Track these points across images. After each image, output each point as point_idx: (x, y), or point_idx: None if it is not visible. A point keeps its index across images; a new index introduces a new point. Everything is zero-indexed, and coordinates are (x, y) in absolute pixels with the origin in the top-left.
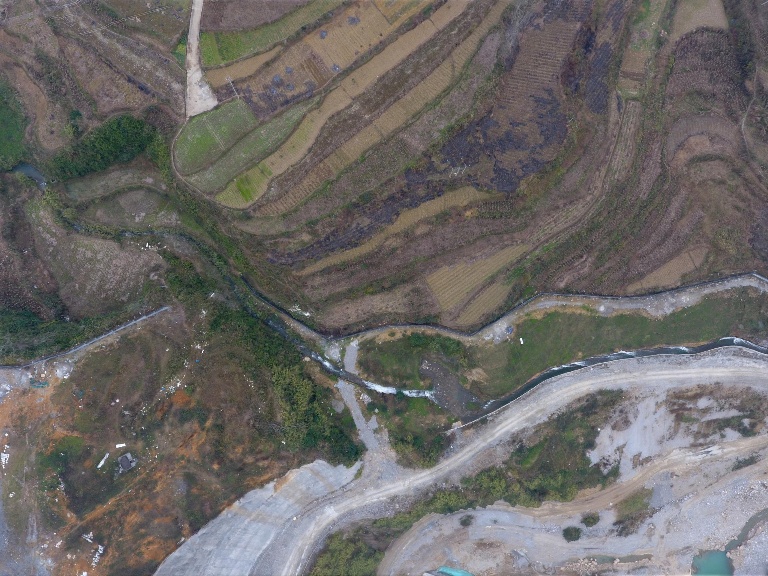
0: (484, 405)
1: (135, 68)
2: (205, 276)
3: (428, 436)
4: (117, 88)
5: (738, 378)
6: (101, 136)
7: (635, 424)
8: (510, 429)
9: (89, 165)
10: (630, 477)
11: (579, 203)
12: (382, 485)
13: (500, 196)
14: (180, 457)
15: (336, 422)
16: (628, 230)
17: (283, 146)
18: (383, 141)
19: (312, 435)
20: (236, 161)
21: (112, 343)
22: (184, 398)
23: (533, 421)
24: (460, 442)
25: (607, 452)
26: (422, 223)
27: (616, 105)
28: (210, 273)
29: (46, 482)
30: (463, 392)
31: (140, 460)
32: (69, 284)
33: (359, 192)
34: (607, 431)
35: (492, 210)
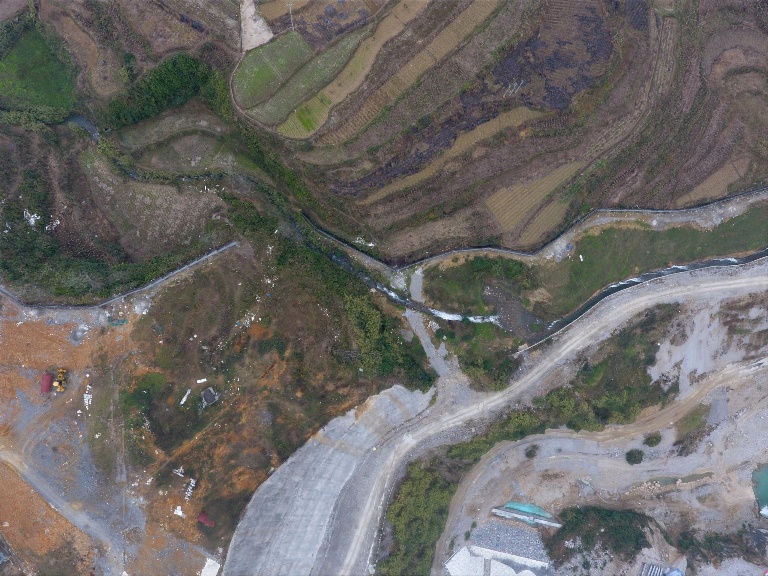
0: (548, 326)
1: (187, 7)
2: (266, 215)
3: (497, 360)
4: (170, 28)
5: None
6: (156, 77)
7: (691, 338)
8: (575, 348)
9: (143, 110)
10: (688, 394)
11: (627, 118)
12: (457, 410)
13: (553, 114)
14: (263, 388)
15: (407, 350)
16: (674, 143)
17: (340, 75)
18: (437, 65)
19: (387, 362)
20: (295, 92)
21: (186, 278)
22: (261, 330)
23: (597, 338)
24: (528, 364)
25: (666, 369)
26: (479, 145)
27: (655, 21)
28: (270, 212)
29: (132, 420)
30: (526, 315)
31: (222, 394)
32: (130, 232)
33: (417, 116)
34: (666, 346)
35: (546, 128)
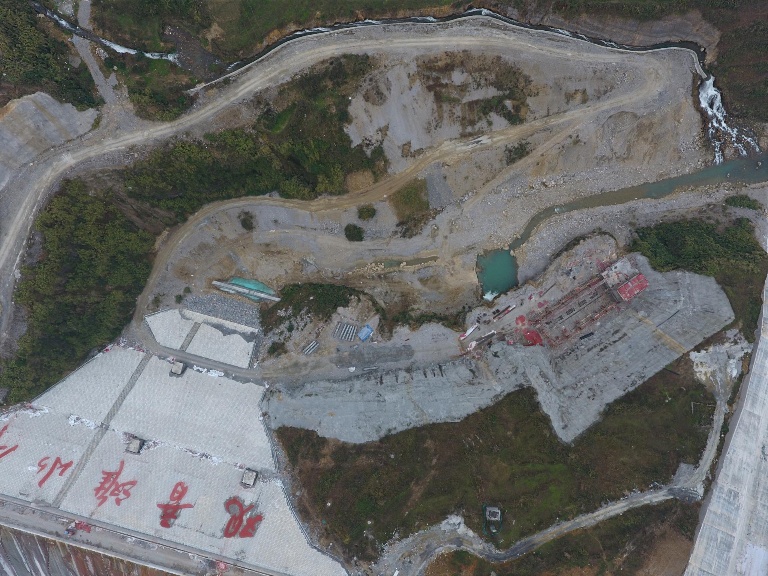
0: (227, 67)
1: None
2: None
3: (170, 94)
4: None
5: (487, 47)
6: None
7: (391, 100)
8: (253, 89)
9: None
10: (402, 168)
11: None
12: (120, 135)
13: None
14: None
15: (71, 73)
16: None
17: None
18: None
19: (38, 74)
20: None
21: None
22: None
23: (276, 81)
24: (203, 101)
25: (369, 133)
26: None
27: None
28: None
29: None
30: (206, 55)
31: None
32: None
33: None
34: (360, 102)
35: None
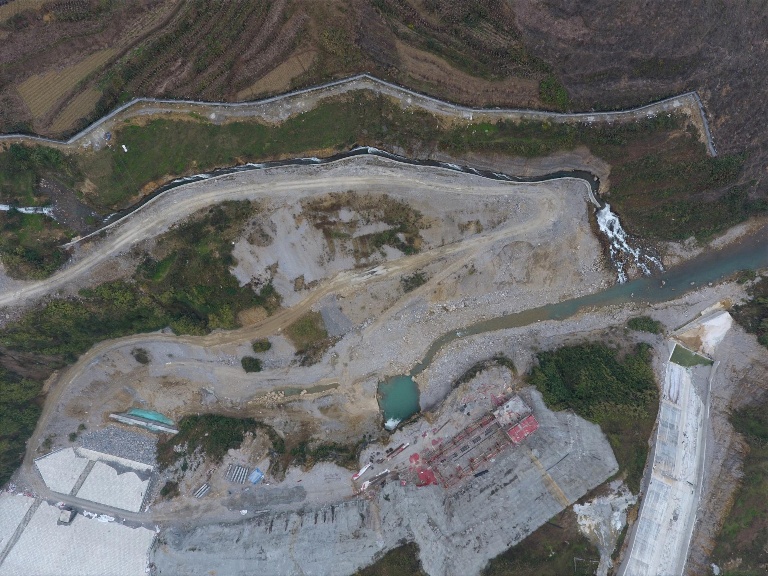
0: (103, 219)
1: None
2: None
3: (44, 250)
4: None
5: (372, 186)
6: None
7: (278, 240)
8: (130, 241)
9: None
10: (296, 301)
11: (165, 5)
12: None
13: None
14: None
15: None
16: (225, 33)
17: None
18: None
19: None
20: None
21: None
22: None
23: (154, 232)
24: (79, 255)
25: (258, 271)
26: None
27: None
28: None
29: None
30: (82, 207)
31: None
32: None
33: None
34: (244, 245)
35: (65, 11)
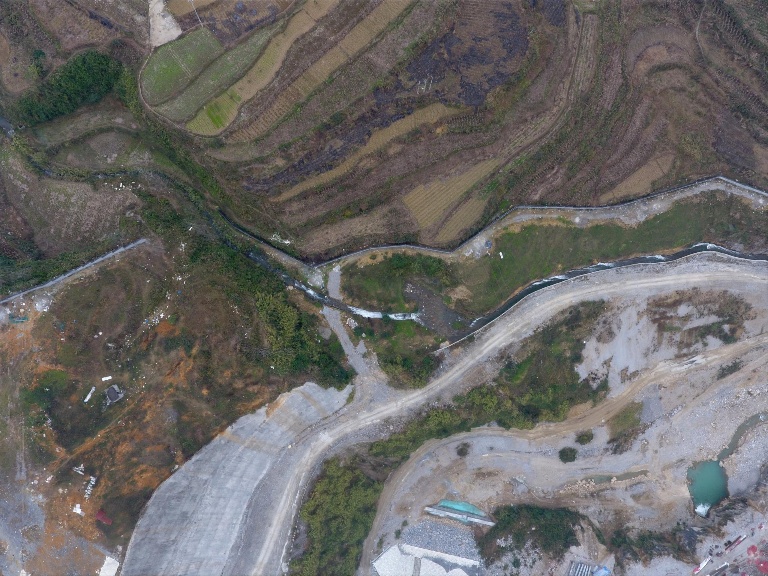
0: (470, 323)
1: (96, 3)
2: (182, 212)
3: (417, 357)
4: (79, 25)
5: (714, 282)
6: (66, 74)
7: (619, 336)
8: (497, 345)
9: (56, 107)
10: (619, 392)
11: (546, 115)
12: (375, 408)
13: (468, 110)
14: (168, 385)
15: (324, 348)
16: (596, 140)
17: (250, 71)
18: (349, 61)
19: (301, 360)
20: (204, 88)
21: (91, 275)
22: (168, 327)
23: (519, 336)
24: (449, 361)
25: (595, 366)
26: (394, 142)
27: (574, 18)
28: (187, 209)
29: (32, 418)
30: (448, 312)
31: (128, 391)
32: (44, 229)
33: (329, 113)
34: (593, 343)
35: (462, 125)
